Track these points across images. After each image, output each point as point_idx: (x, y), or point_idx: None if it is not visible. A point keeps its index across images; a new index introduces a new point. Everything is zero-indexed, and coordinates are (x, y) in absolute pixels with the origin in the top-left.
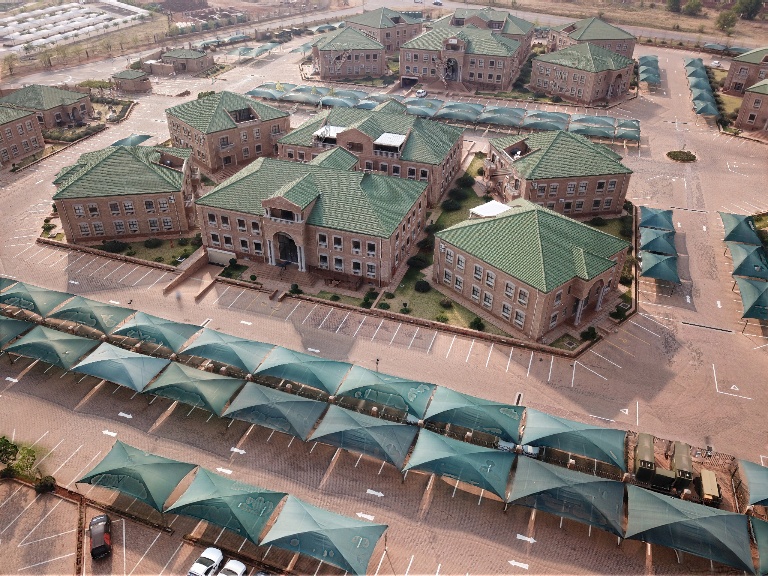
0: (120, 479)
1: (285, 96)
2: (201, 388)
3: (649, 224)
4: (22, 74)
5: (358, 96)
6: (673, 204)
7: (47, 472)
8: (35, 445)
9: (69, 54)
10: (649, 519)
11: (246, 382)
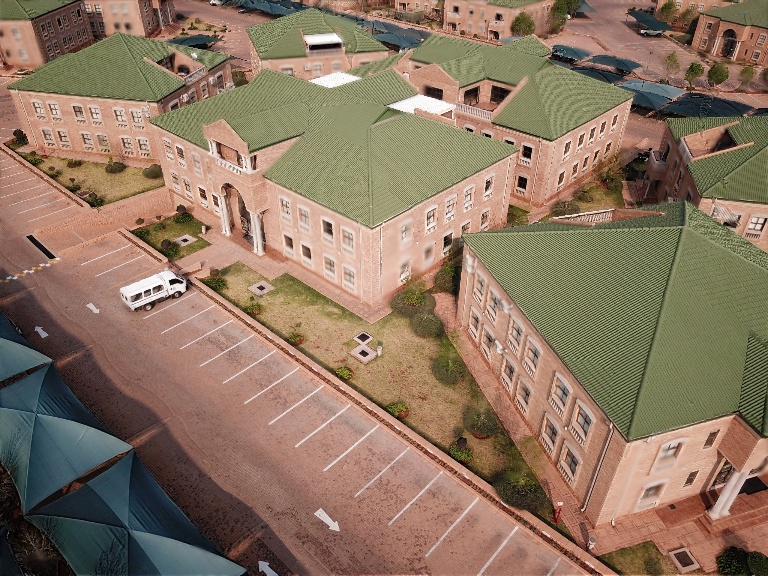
0: None
1: None
2: None
3: None
4: None
5: None
6: None
7: None
8: None
9: None
10: (393, 27)
11: None
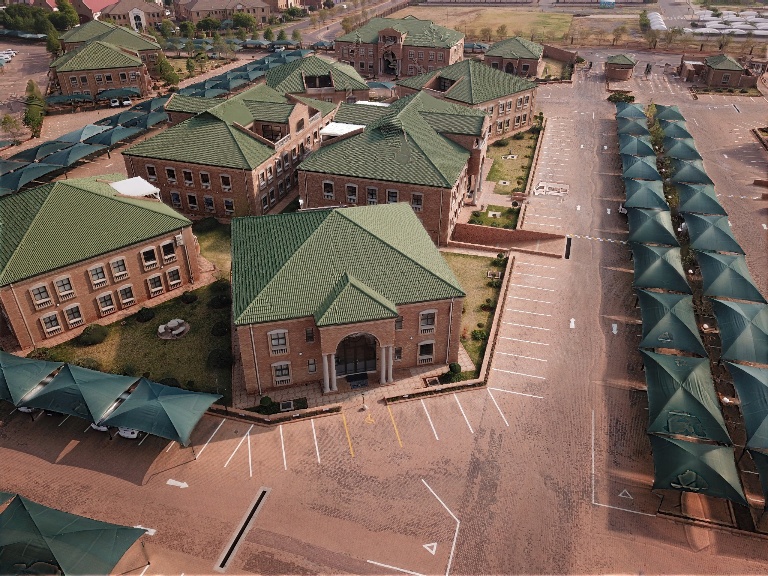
0: (3, 157)
1: (621, 117)
2: (33, 149)
3: (139, 389)
4: (620, 47)
5: (669, 151)
6: (279, 500)
7: (28, 143)
8: (53, 138)
9: (673, 41)
10: None
11: (33, 162)
